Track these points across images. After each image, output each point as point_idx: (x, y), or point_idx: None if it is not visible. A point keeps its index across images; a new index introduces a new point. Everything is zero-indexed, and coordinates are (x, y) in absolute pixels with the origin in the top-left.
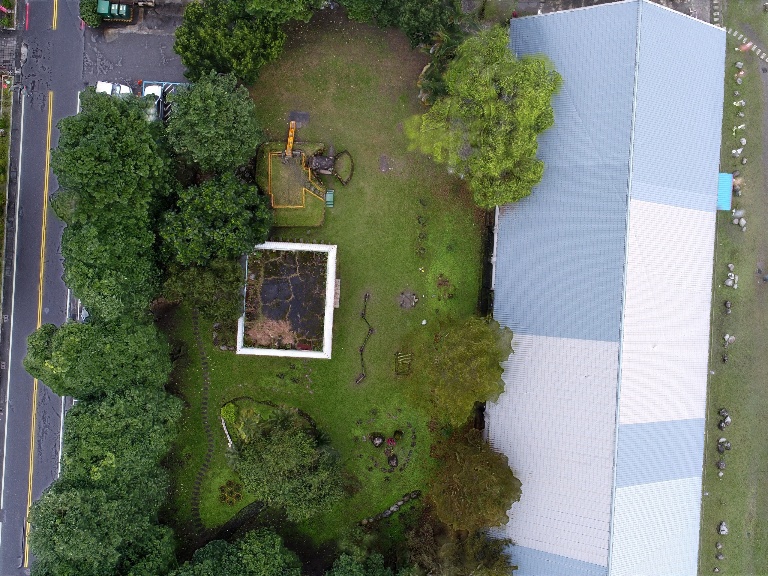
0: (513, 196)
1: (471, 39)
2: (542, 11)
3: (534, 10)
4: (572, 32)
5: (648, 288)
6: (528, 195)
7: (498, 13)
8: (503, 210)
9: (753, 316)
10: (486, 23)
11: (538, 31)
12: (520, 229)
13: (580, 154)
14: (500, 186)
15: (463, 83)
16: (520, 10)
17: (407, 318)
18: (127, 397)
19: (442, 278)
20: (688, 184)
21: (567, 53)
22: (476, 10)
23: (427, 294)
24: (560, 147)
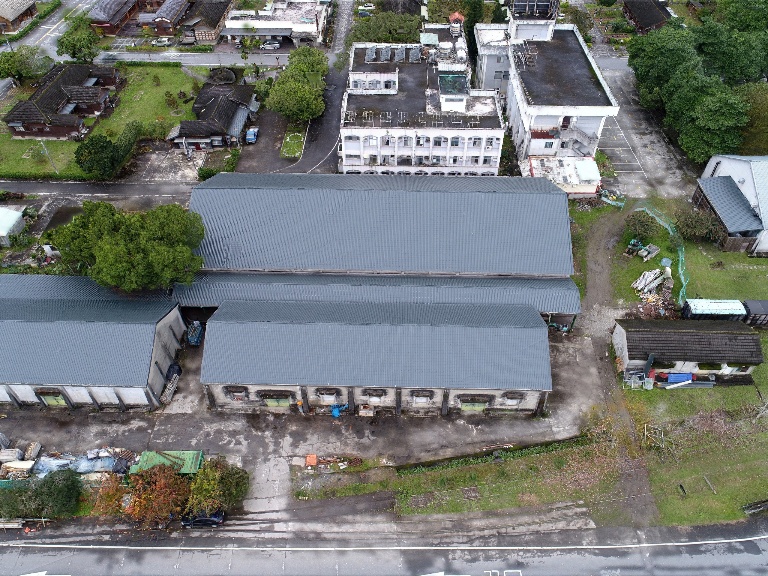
0: None
1: None
2: None
3: None
4: None
5: None
6: None
7: None
8: None
9: None
10: None
11: None
12: None
13: None
14: None
15: None
16: None
17: None
18: (760, 52)
19: None
20: None
21: None
22: None
23: None
24: None
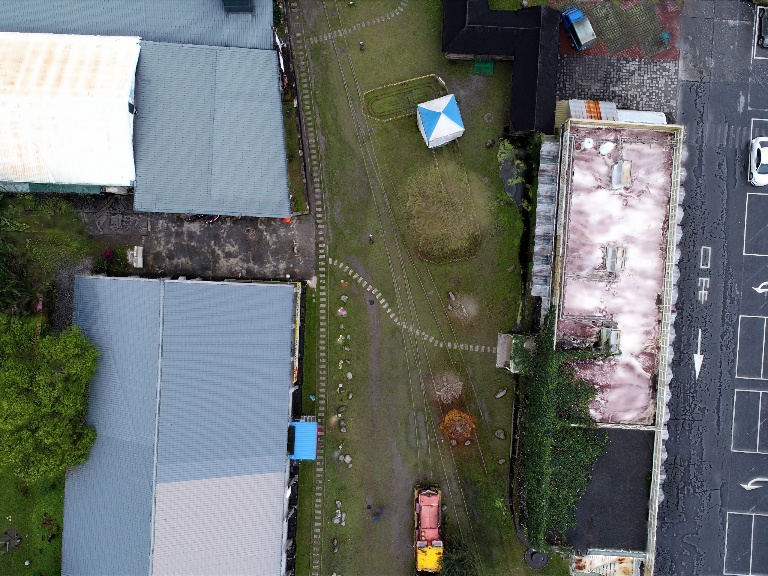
0: (68, 463)
1: (73, 273)
2: (144, 244)
3: (136, 243)
4: (116, 301)
5: (187, 567)
6: (86, 460)
7: (99, 247)
8: (68, 471)
9: (361, 554)
10: (87, 257)
11: (93, 293)
12: (80, 493)
13: (122, 428)
14: (19, 474)
15: (65, 318)
16: (122, 243)
17: (11, 558)
18: None
19: (46, 517)
20: (244, 450)
21: (113, 321)
22: (77, 244)
23: (31, 534)
24: (108, 416)
